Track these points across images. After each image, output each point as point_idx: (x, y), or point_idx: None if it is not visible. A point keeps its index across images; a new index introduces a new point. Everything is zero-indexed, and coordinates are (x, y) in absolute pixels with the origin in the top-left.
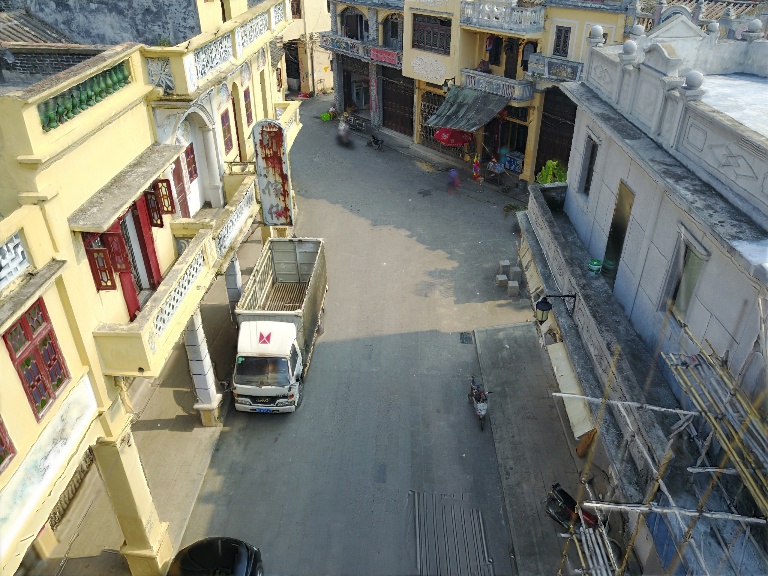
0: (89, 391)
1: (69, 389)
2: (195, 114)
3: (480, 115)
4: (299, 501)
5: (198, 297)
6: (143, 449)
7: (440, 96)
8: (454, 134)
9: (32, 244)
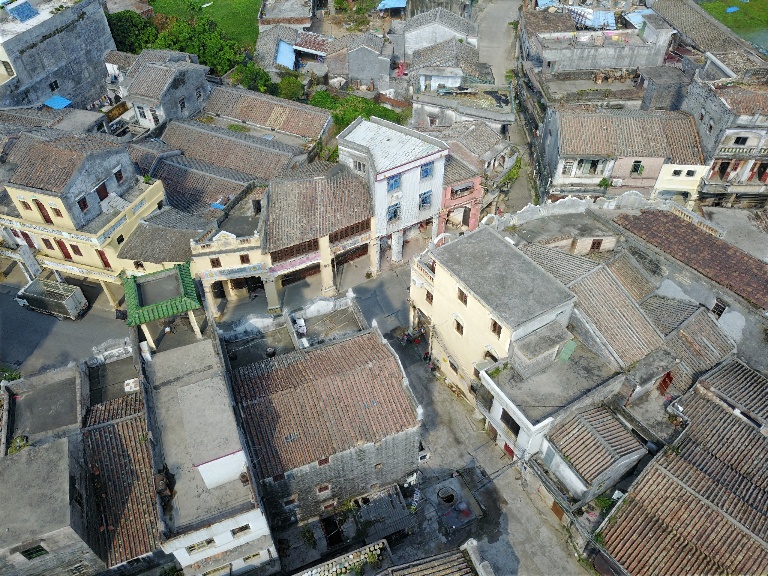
0: None
1: None
2: None
3: None
4: None
5: None
6: None
7: None
8: None
9: None
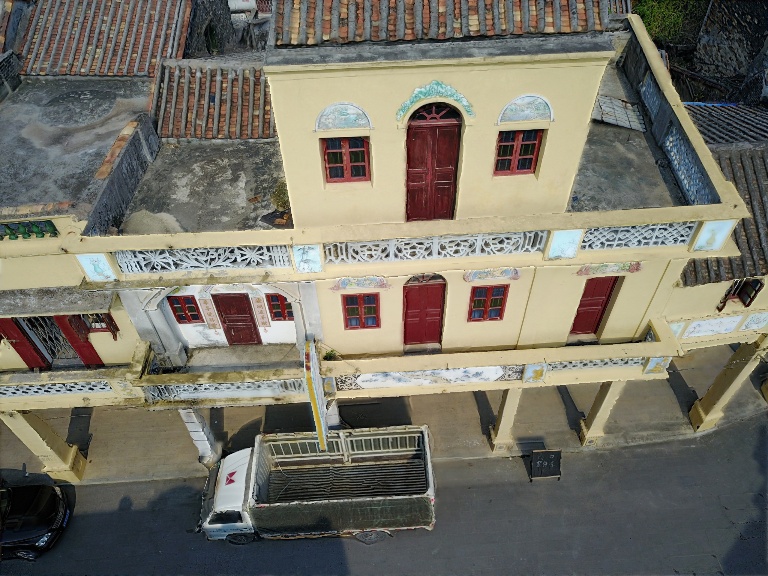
0: None
1: None
2: None
3: None
4: (109, 572)
5: (70, 404)
6: None
7: None
8: None
9: None
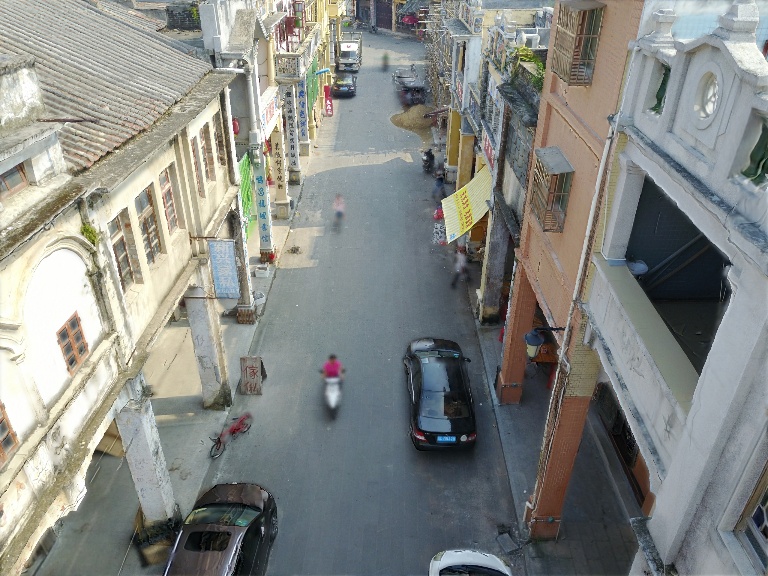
0: None
1: None
2: None
3: None
4: None
5: (341, 12)
6: None
7: None
8: (411, 18)
9: None
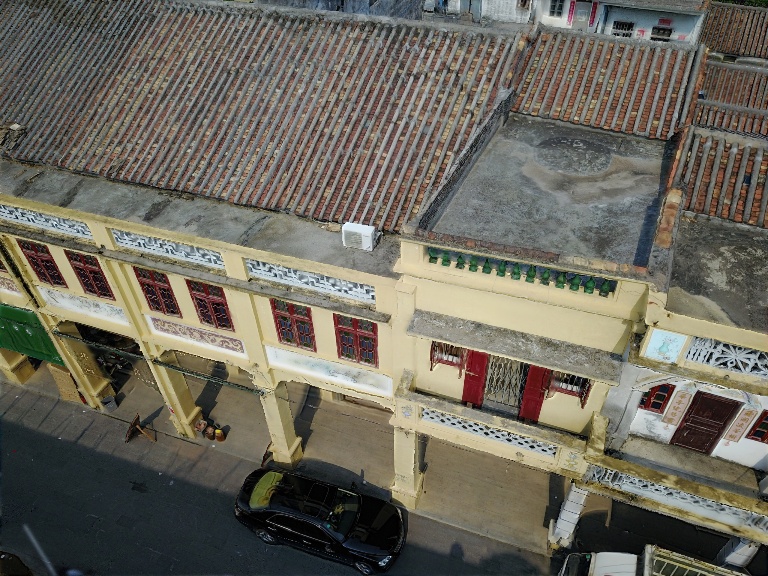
0: None
1: (370, 369)
2: None
3: None
4: None
5: (502, 454)
6: (525, 485)
7: None
8: None
9: (376, 298)
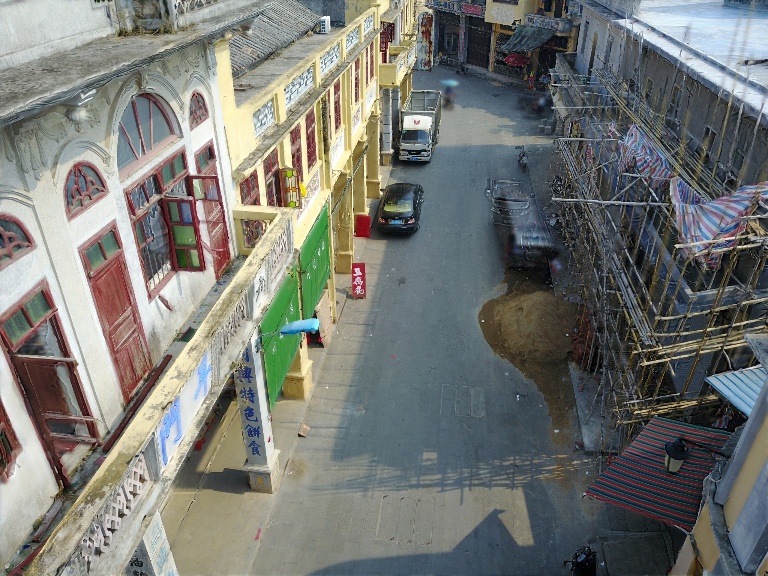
0: (375, 88)
1: None
2: (395, 5)
3: (536, 42)
4: (435, 186)
5: (404, 73)
6: None
7: (510, 36)
8: (518, 58)
9: None
